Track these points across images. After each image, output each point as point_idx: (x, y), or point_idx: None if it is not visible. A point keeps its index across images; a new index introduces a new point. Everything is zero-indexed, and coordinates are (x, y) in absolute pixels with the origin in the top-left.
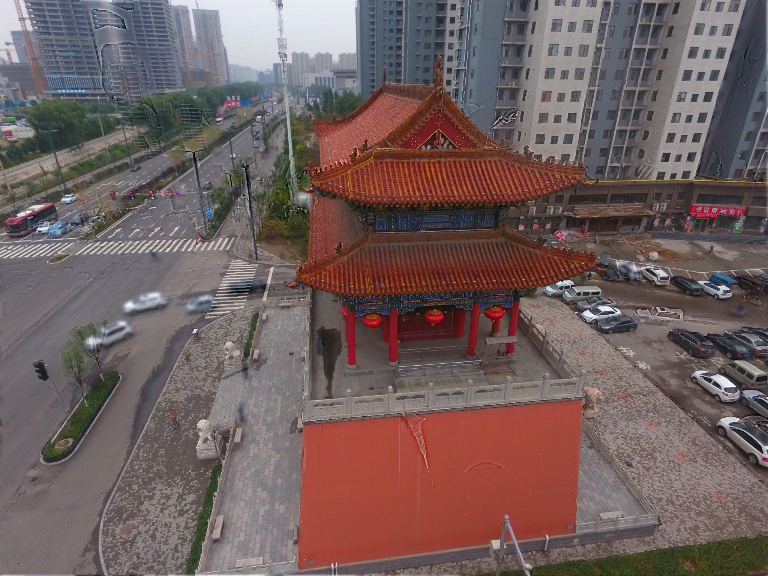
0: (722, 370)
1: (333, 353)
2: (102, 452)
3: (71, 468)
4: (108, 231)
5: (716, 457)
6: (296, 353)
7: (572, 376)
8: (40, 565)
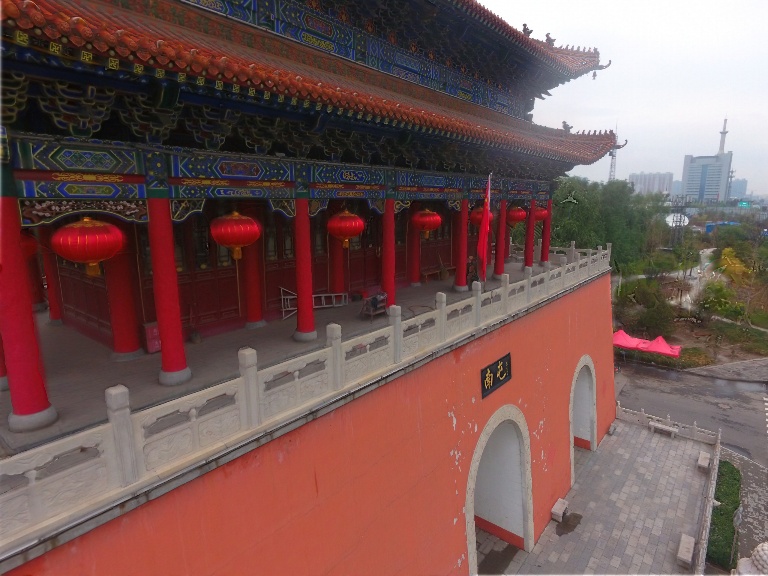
0: None
1: None
2: None
3: None
4: None
5: None
6: None
7: None
8: None
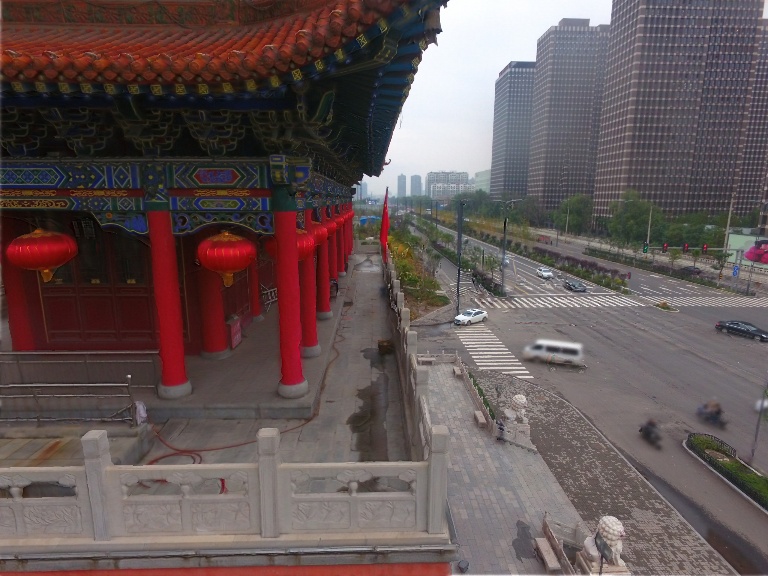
0: None
1: (364, 264)
2: (653, 449)
3: (663, 437)
4: None
5: None
6: None
7: None
8: (584, 389)
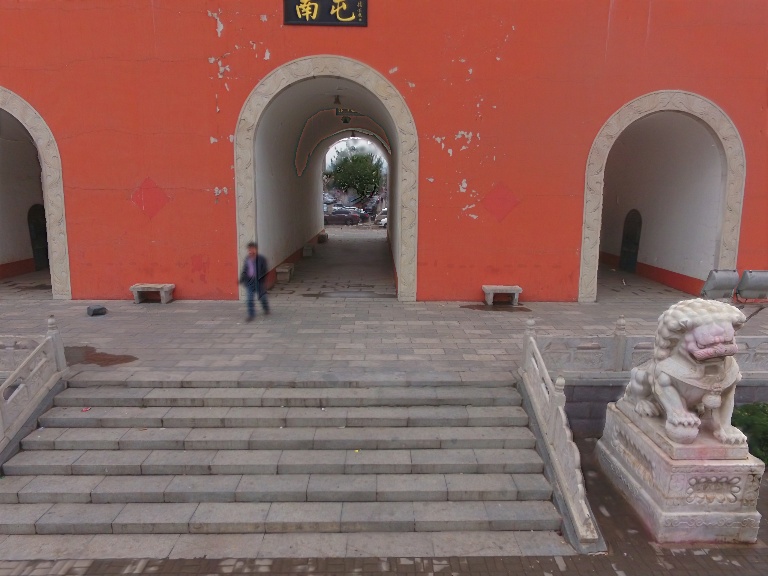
0: (378, 222)
1: None
2: None
3: None
4: None
5: None
6: (106, 308)
7: None
8: None
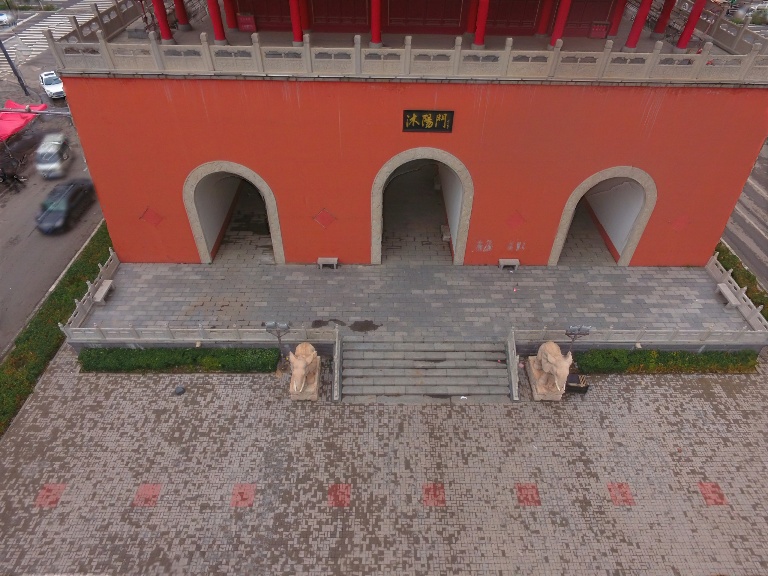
0: None
1: None
2: None
3: None
4: (763, 27)
5: (107, 574)
6: None
7: (76, 53)
8: None
